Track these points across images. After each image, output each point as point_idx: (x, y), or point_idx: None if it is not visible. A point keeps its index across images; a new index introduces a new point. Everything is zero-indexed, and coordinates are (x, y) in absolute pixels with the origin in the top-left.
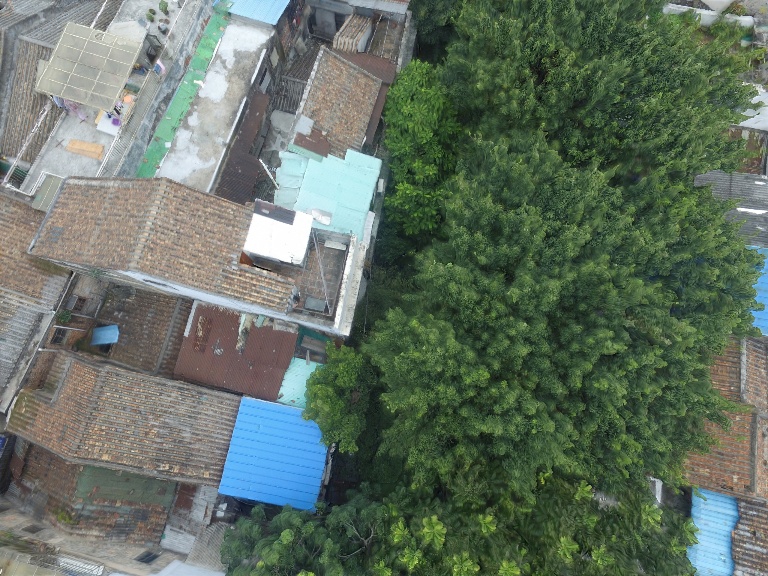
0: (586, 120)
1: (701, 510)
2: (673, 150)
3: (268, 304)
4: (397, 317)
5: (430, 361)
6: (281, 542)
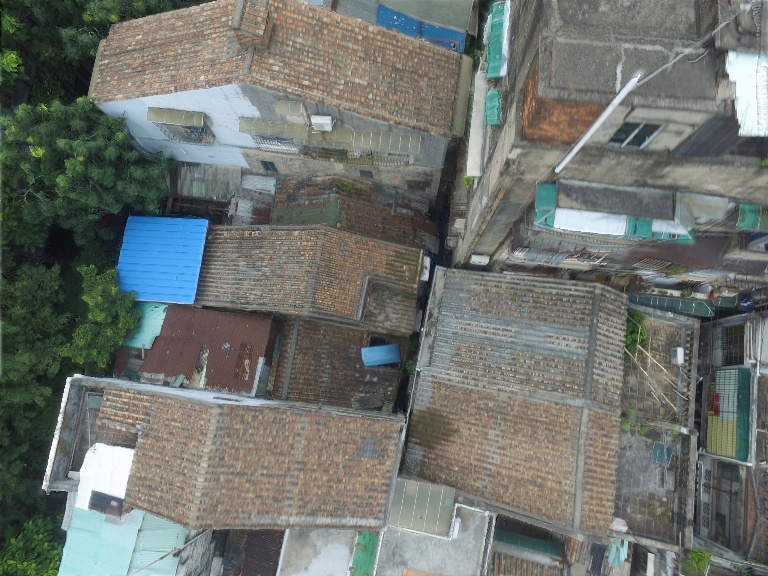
0: None
1: None
2: None
3: (117, 392)
4: None
5: None
6: (66, 175)
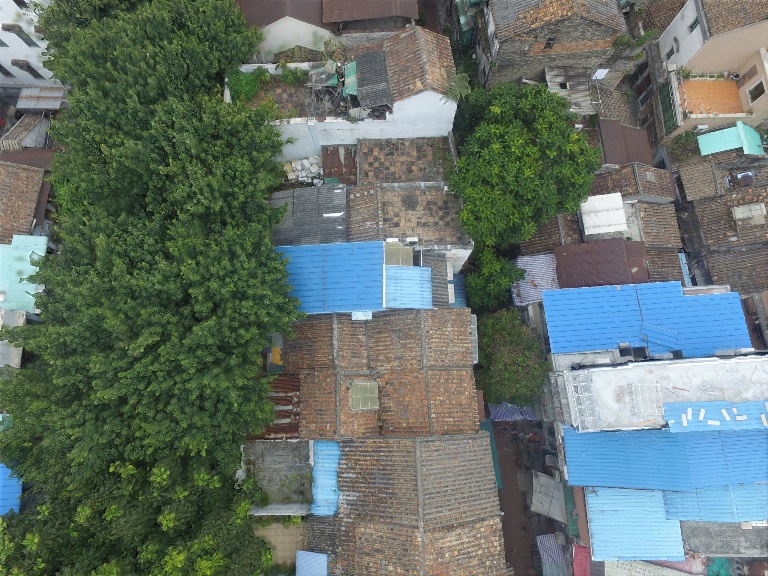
0: (148, 183)
1: (319, 456)
2: (195, 198)
3: None
4: (3, 372)
5: (4, 403)
6: None
